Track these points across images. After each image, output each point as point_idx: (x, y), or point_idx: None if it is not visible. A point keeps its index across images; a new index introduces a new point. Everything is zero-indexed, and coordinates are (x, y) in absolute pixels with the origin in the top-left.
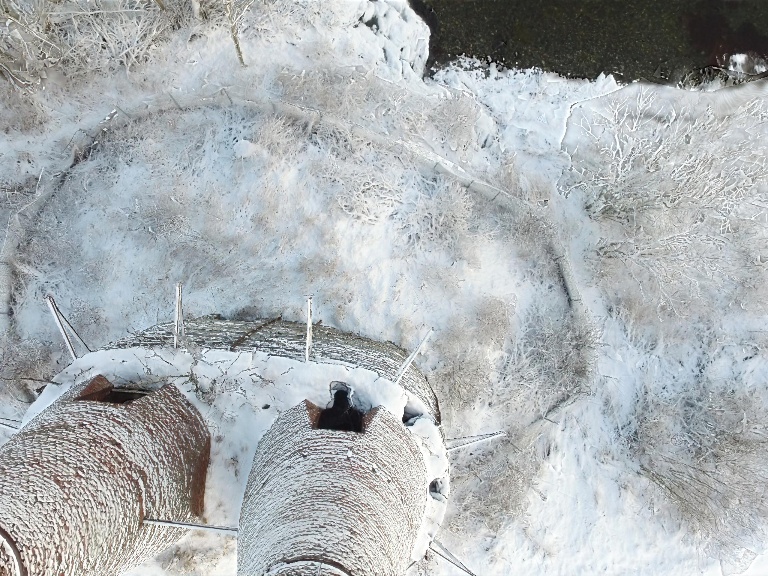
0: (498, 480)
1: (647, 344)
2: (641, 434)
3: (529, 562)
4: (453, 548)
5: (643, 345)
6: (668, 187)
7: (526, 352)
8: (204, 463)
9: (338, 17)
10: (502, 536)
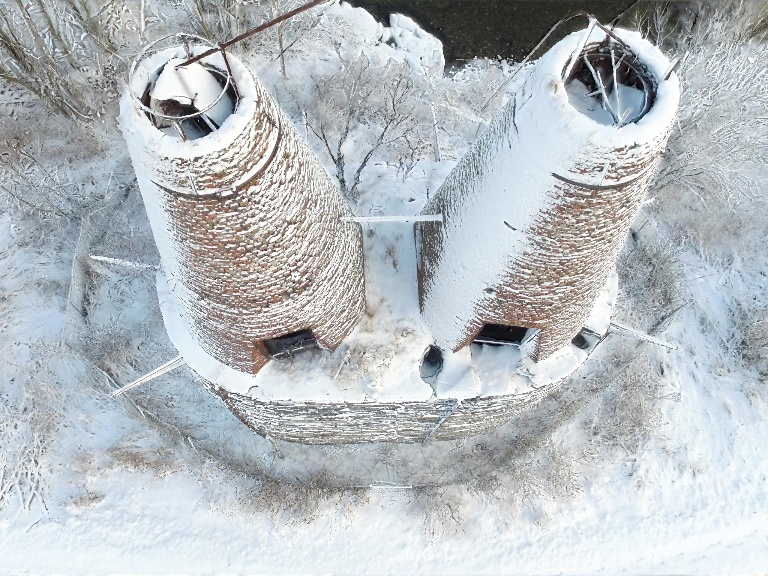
0: (622, 393)
1: (723, 261)
2: (749, 341)
3: (679, 484)
4: (593, 479)
5: (719, 263)
6: (705, 84)
7: None
8: None
9: (361, 38)
10: (642, 458)
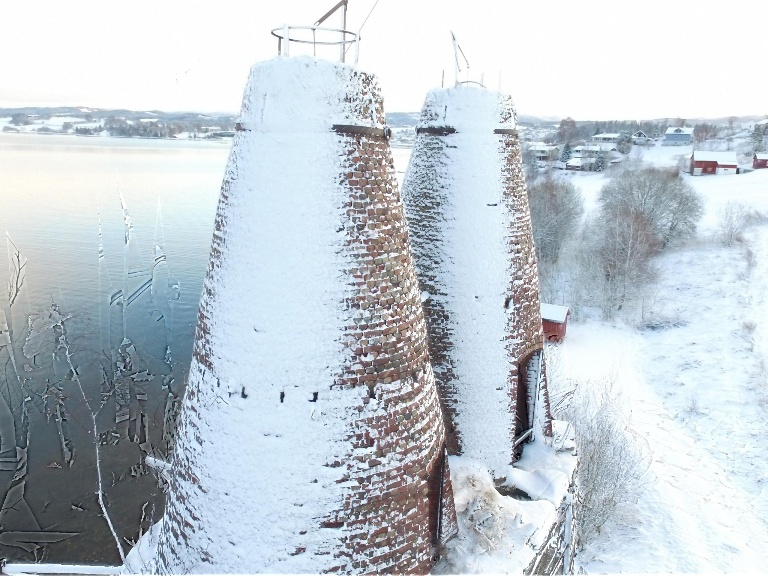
0: None
1: None
2: None
3: None
4: None
5: None
6: None
7: None
8: None
9: None
10: None
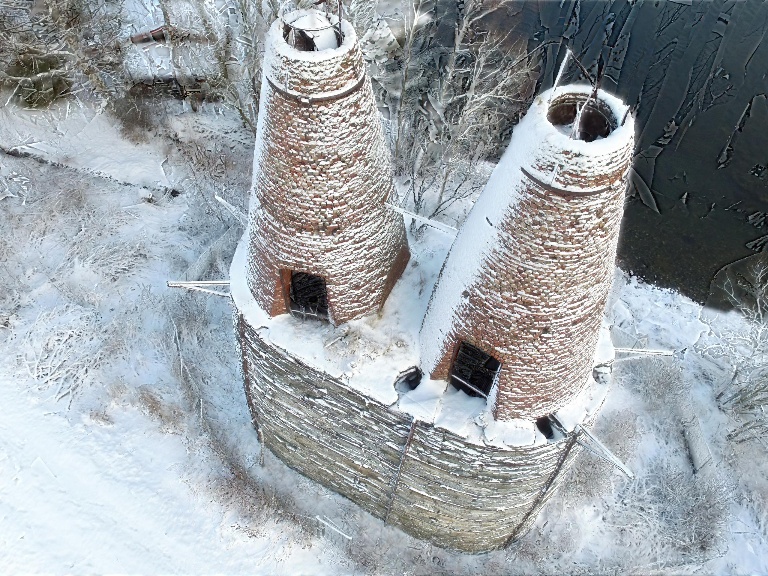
0: None
1: None
2: None
3: None
4: None
5: None
6: None
7: (648, 488)
8: (401, 268)
9: None
10: None
